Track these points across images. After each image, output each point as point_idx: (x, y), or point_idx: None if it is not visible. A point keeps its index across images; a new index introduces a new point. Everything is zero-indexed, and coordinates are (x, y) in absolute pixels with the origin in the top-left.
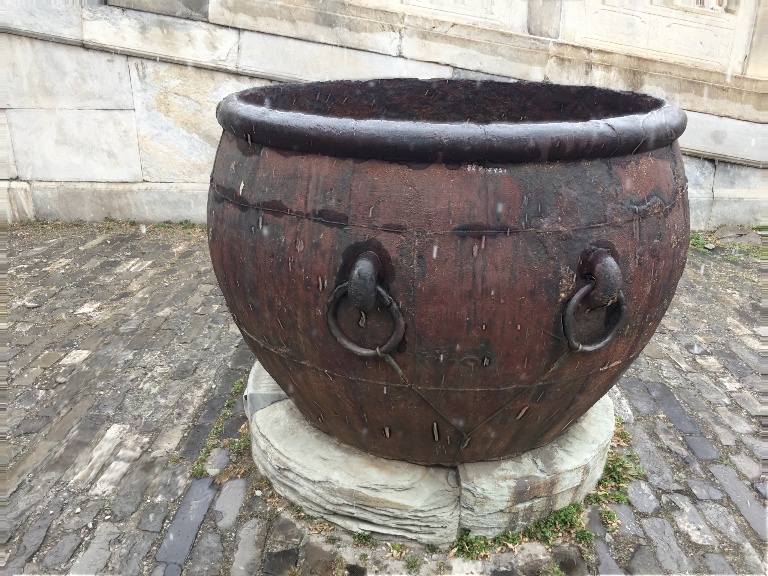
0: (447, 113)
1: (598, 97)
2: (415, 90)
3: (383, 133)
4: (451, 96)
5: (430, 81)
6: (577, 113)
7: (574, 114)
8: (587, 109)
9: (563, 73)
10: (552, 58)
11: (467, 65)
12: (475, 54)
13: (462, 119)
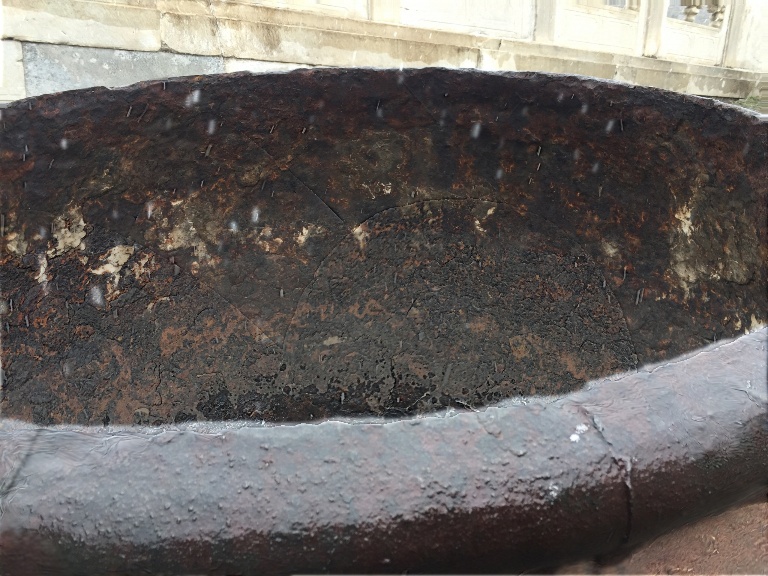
0: (170, 142)
1: (453, 85)
2: (106, 111)
3: (727, 438)
4: (176, 111)
5: (132, 89)
6: (406, 112)
7: (400, 114)
8: (426, 104)
9: (184, 36)
10: (164, 16)
11: (43, 36)
12: (51, 18)
13: (198, 147)
